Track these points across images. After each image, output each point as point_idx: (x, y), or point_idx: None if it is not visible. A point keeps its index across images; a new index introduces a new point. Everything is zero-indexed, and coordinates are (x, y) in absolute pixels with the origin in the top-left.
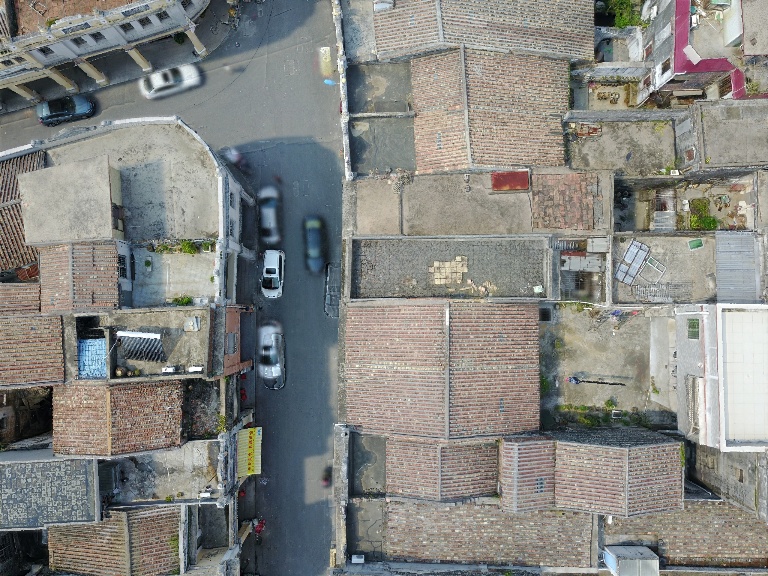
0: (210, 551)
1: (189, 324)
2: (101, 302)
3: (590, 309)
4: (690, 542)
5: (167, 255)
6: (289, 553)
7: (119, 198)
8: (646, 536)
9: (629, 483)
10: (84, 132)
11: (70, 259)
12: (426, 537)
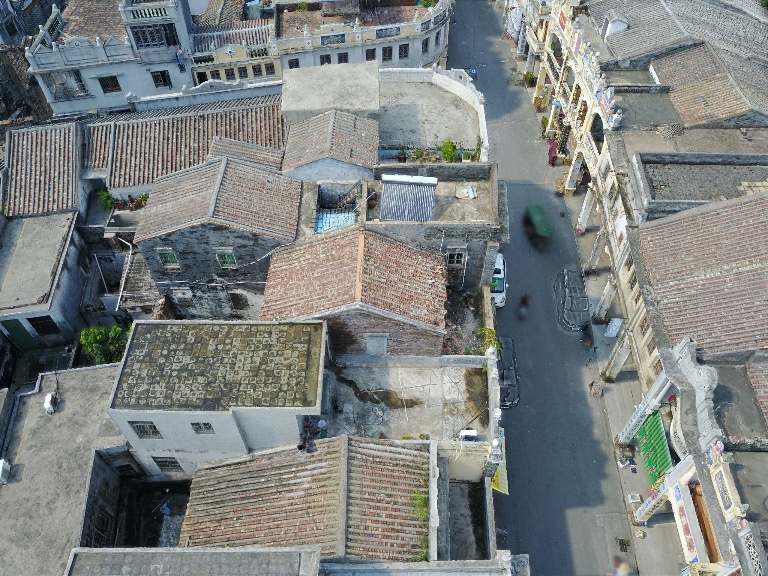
0: None
1: (463, 191)
2: None
3: None
4: None
5: None
6: None
7: None
8: None
9: None
10: None
11: (332, 118)
12: None
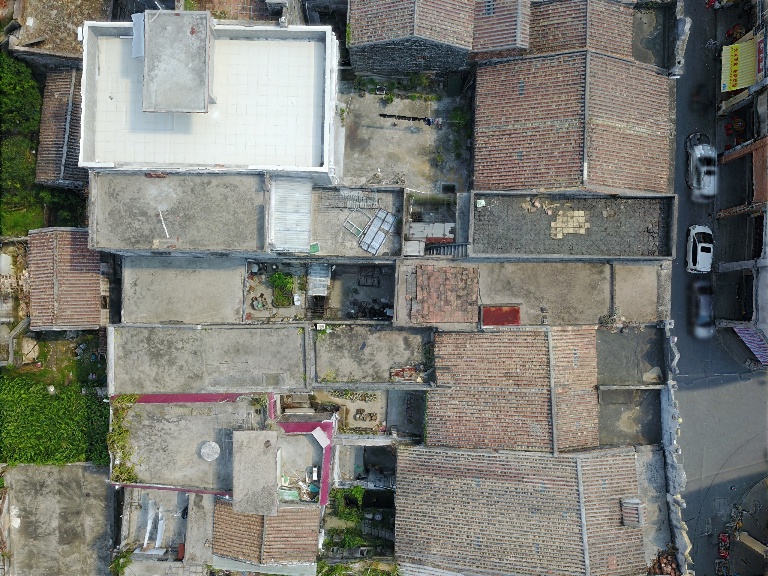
0: None
1: None
2: None
3: None
4: None
5: None
6: None
7: None
8: None
9: (413, 3)
10: None
11: None
12: None
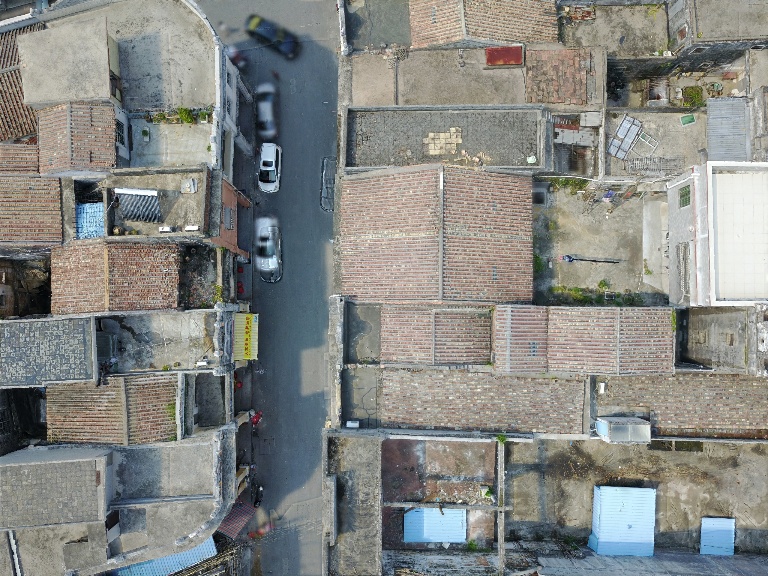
0: (207, 427)
1: (186, 186)
2: (99, 162)
3: (583, 192)
4: (681, 413)
5: (164, 126)
6: (285, 444)
7: (117, 69)
8: (638, 408)
9: (620, 342)
10: (82, 2)
11: (68, 117)
12: (420, 404)
